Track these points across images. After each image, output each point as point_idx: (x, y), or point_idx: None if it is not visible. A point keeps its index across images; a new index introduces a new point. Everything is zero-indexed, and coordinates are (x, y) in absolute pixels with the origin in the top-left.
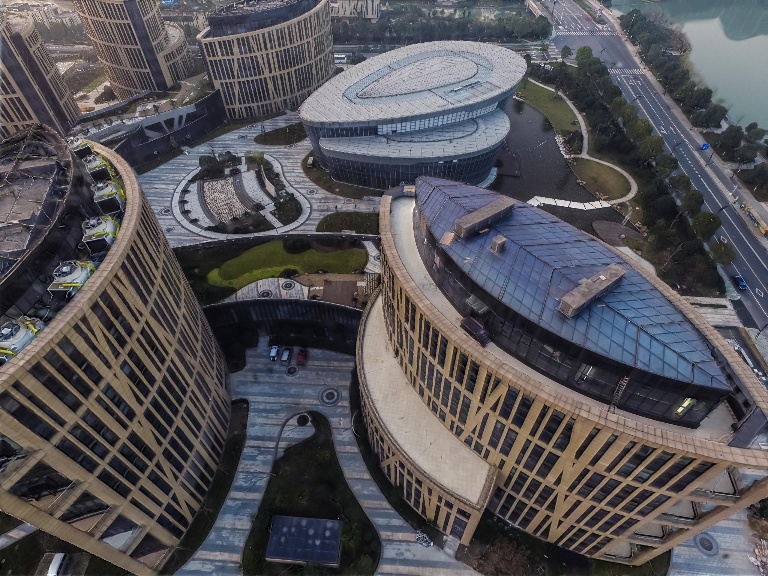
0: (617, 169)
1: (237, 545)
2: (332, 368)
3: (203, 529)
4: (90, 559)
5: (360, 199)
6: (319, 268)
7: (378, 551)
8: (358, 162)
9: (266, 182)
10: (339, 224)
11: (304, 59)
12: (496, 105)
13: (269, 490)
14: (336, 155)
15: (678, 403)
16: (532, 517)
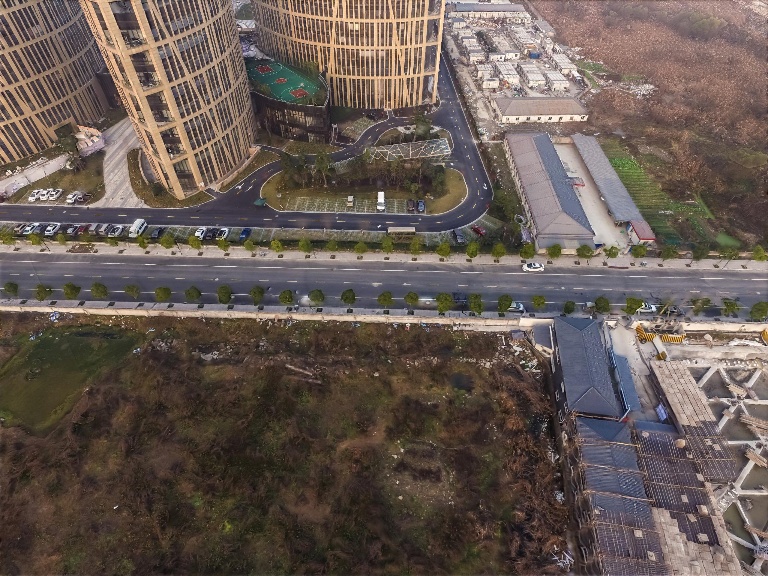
0: None
1: None
2: None
3: None
4: None
5: None
6: None
7: None
8: None
9: None
10: (246, 15)
11: None
12: None
13: None
14: None
15: None
16: None
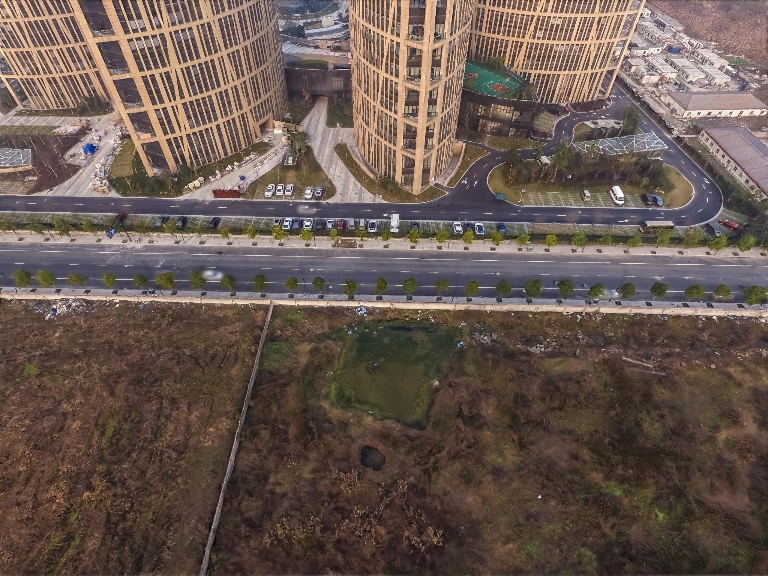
0: None
1: None
2: None
3: None
4: None
5: None
6: None
7: None
8: None
9: (324, 21)
10: None
11: None
12: None
13: None
14: None
15: None
16: None
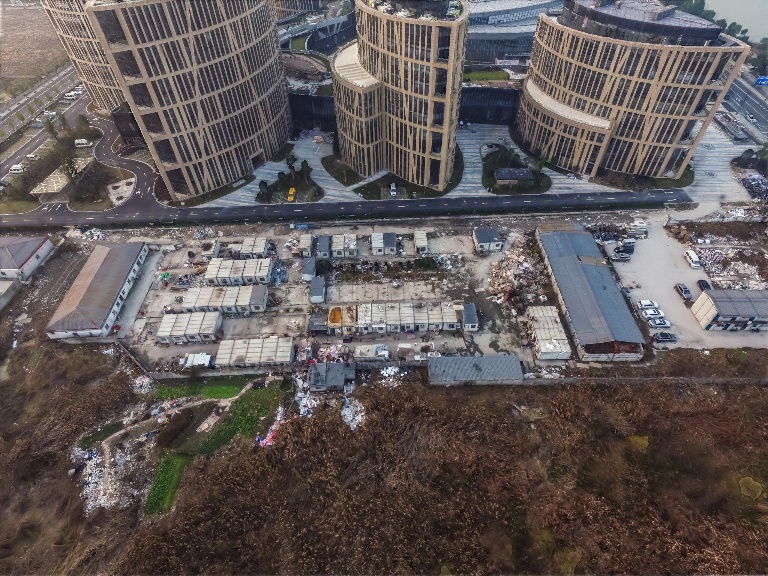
0: None
1: (478, 182)
2: (496, 130)
3: (458, 178)
4: (406, 188)
5: None
6: (482, 78)
7: None
8: (477, 40)
9: None
10: None
11: None
12: None
13: (485, 167)
14: None
15: None
16: (628, 153)
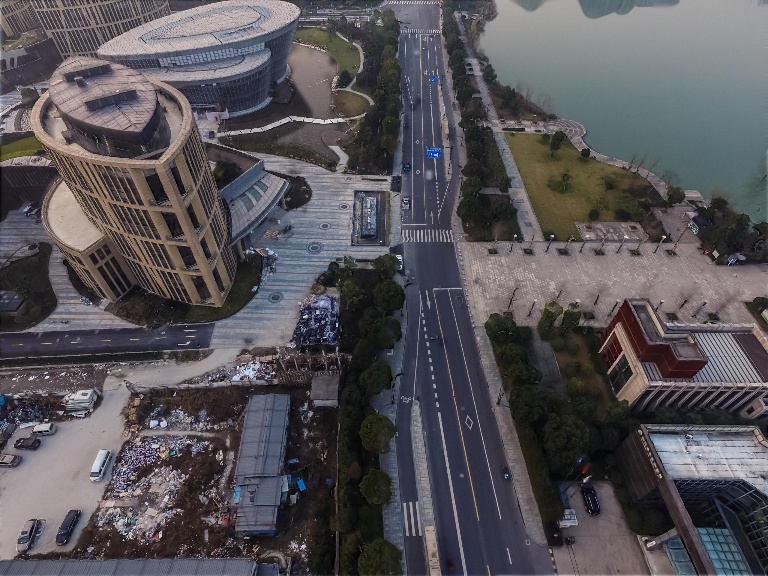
0: (366, 98)
1: None
2: None
3: None
4: None
5: None
6: None
7: (52, 308)
8: None
9: None
10: None
11: (130, 14)
12: (264, 45)
13: None
14: None
15: (139, 152)
16: None
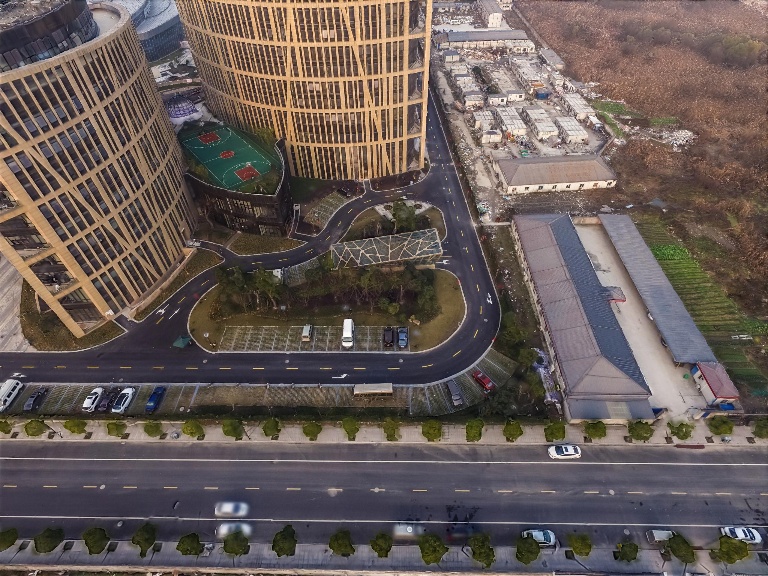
0: None
1: None
2: None
3: None
4: None
5: (184, 54)
6: None
7: None
8: (165, 31)
9: None
10: None
11: None
12: None
13: None
14: (154, 33)
15: None
16: None
